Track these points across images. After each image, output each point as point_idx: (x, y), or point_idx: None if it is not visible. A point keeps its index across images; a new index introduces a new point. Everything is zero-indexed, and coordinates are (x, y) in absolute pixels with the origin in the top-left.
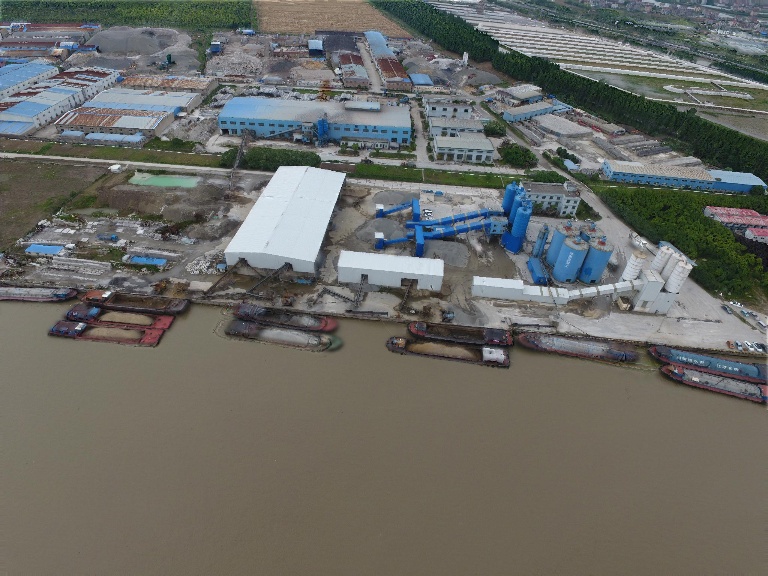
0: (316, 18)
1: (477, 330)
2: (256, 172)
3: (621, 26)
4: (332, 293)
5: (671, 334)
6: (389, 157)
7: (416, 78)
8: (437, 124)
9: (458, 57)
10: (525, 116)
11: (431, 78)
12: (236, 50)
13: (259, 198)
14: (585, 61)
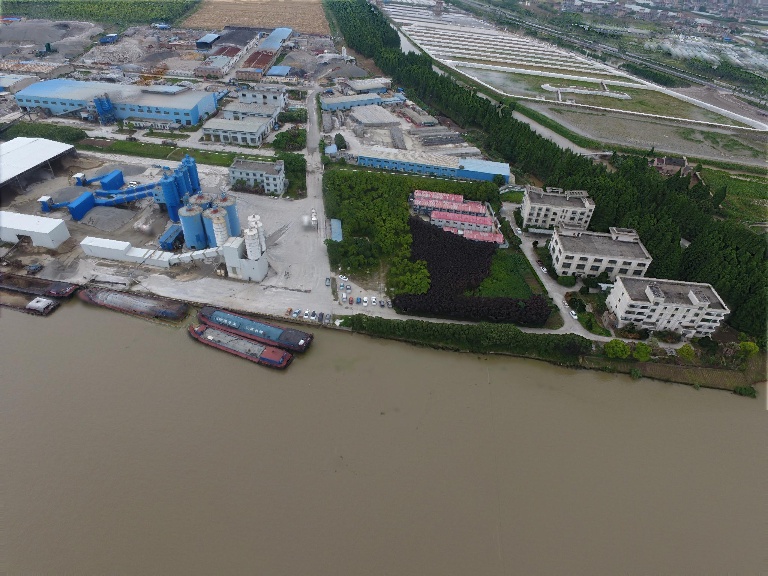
0: (252, 16)
1: (50, 283)
2: None
3: (573, 29)
4: None
5: (242, 299)
6: (161, 136)
7: (274, 69)
8: (229, 108)
9: (354, 53)
10: (343, 106)
11: (292, 70)
12: (133, 42)
13: None
14: (486, 60)
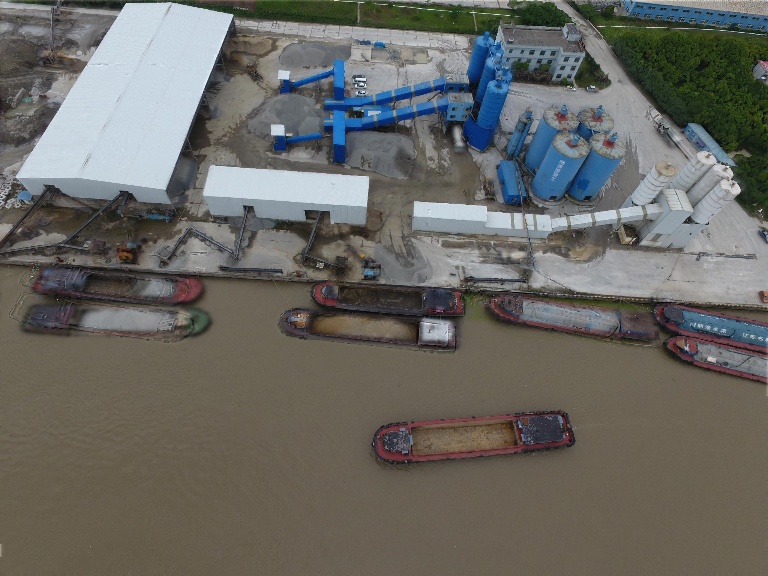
0: None
1: (414, 292)
2: (99, 11)
3: None
4: (201, 236)
5: (686, 282)
6: None
7: None
8: None
9: None
10: None
11: None
12: None
13: (85, 67)
14: None
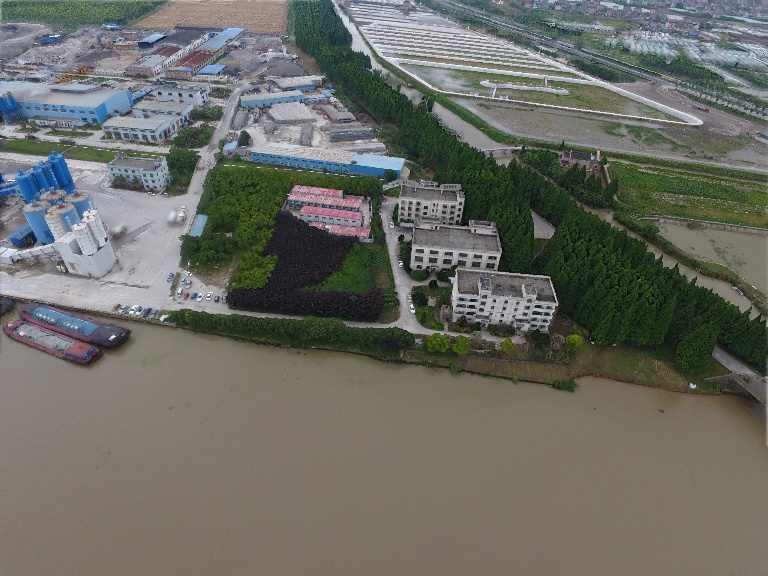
0: (211, 17)
1: None
2: None
3: (538, 26)
4: None
5: (74, 295)
6: (63, 135)
7: (207, 68)
8: (139, 106)
9: (300, 52)
10: (263, 103)
11: (226, 69)
12: (77, 43)
13: None
14: (435, 57)
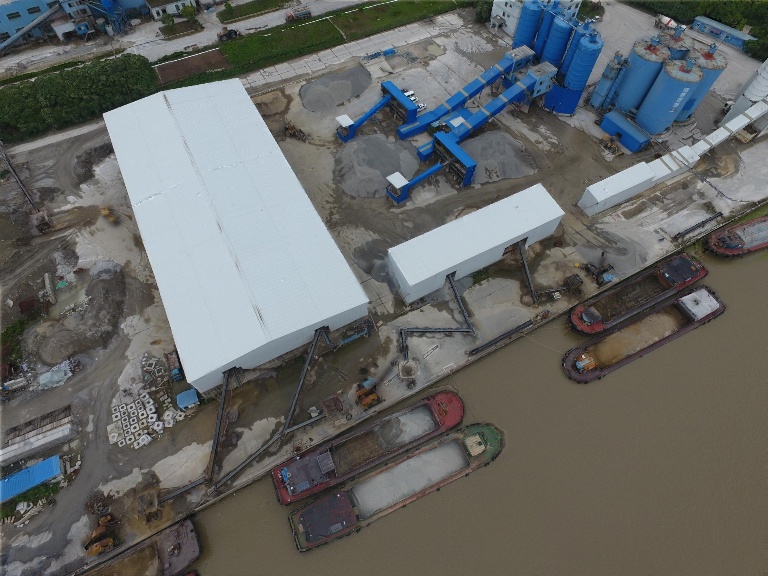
0: None
1: (649, 274)
2: (48, 139)
3: None
4: (418, 332)
5: None
6: (254, 12)
7: None
8: None
9: None
10: None
11: None
12: None
13: (134, 209)
14: None
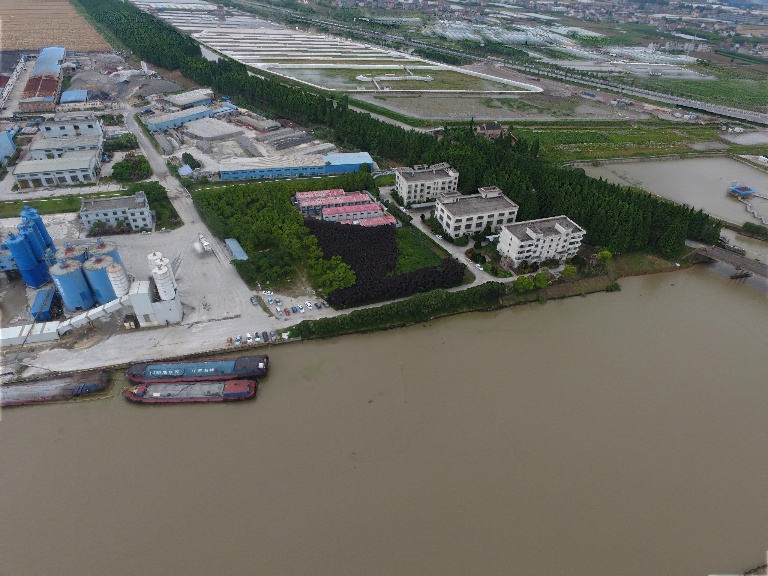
0: None
1: None
2: None
3: (357, 23)
4: None
5: (169, 345)
6: None
7: (67, 95)
8: (37, 147)
9: (152, 67)
10: (173, 123)
11: (90, 93)
12: None
13: None
14: (294, 59)
